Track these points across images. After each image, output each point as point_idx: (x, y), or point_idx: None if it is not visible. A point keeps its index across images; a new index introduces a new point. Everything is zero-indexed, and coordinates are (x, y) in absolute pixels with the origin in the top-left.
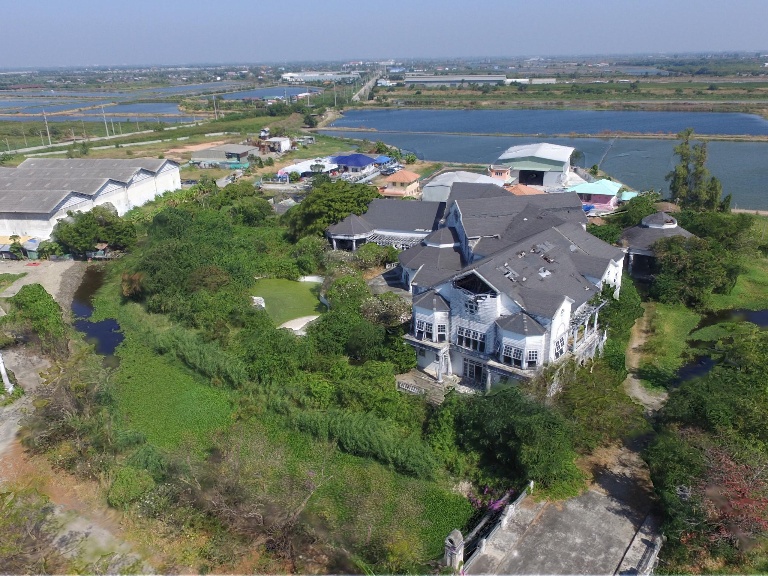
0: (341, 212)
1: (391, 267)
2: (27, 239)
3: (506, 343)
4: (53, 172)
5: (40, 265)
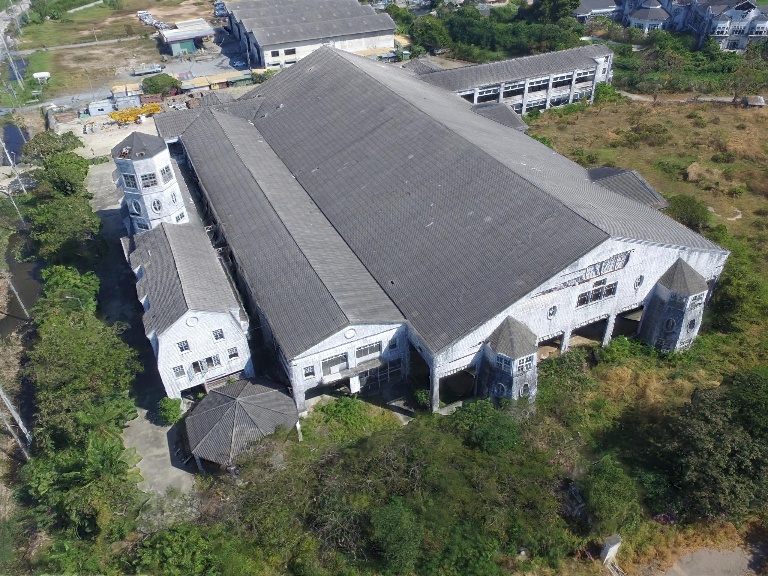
0: None
1: (607, 28)
2: (392, 48)
3: (758, 26)
4: (294, 8)
5: None
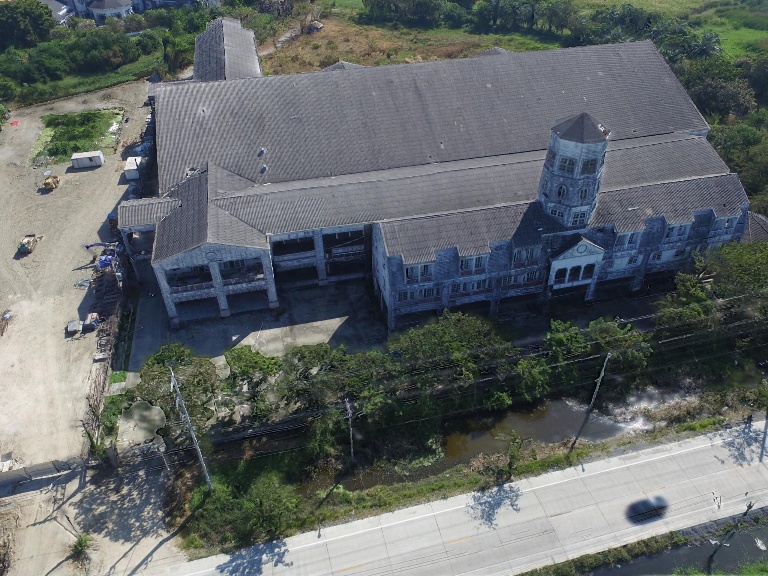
0: (49, 8)
1: None
2: None
3: None
4: None
5: (18, 120)
